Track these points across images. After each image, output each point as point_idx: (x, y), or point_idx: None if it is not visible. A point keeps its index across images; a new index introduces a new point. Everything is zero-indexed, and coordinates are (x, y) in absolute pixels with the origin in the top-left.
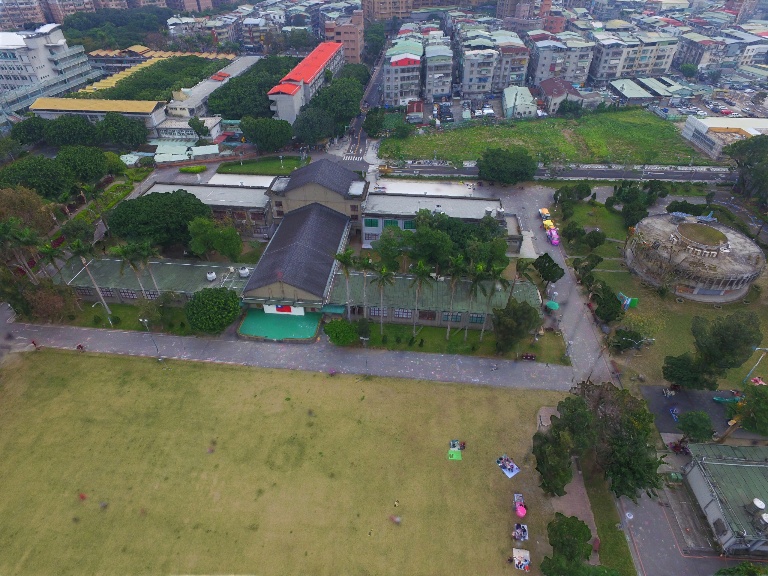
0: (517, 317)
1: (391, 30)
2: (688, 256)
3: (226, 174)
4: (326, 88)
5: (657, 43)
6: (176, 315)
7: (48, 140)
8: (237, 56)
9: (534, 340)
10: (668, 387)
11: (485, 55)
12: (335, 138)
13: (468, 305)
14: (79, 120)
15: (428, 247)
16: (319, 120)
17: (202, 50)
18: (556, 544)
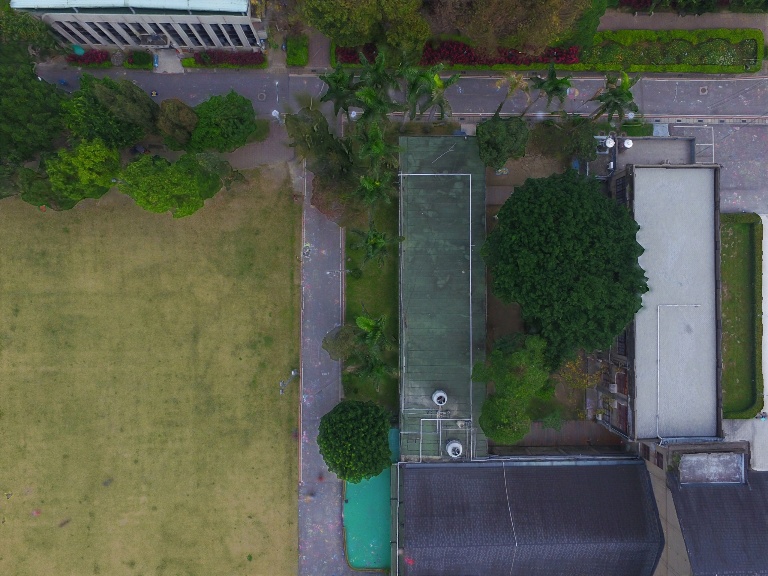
0: None
1: None
2: None
3: None
4: None
5: None
6: None
7: None
8: None
9: None
10: None
11: None
12: None
13: None
14: None
15: None
16: None
17: None
18: None
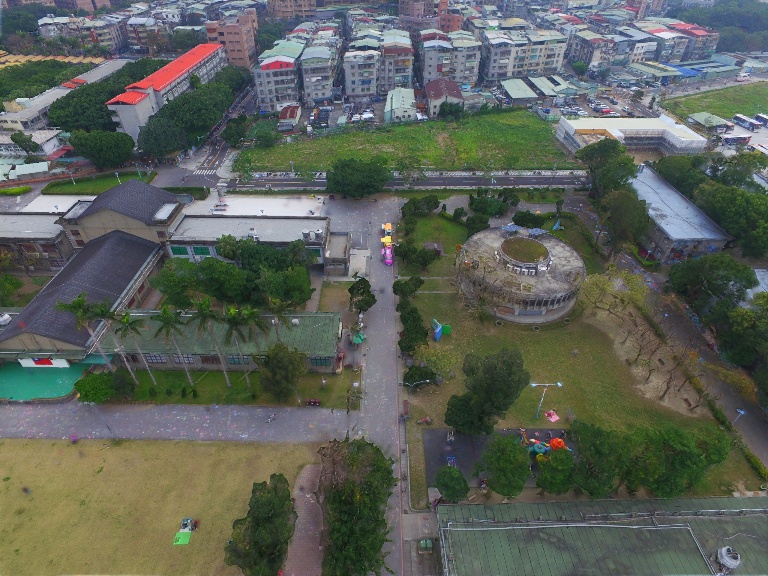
0: (273, 366)
1: None
2: (507, 275)
3: (52, 195)
4: (186, 95)
5: (545, 42)
6: None
7: None
8: (107, 59)
9: None
10: (453, 429)
11: (365, 56)
12: (189, 150)
13: (255, 345)
14: None
15: (214, 281)
16: (164, 131)
17: (67, 53)
18: None
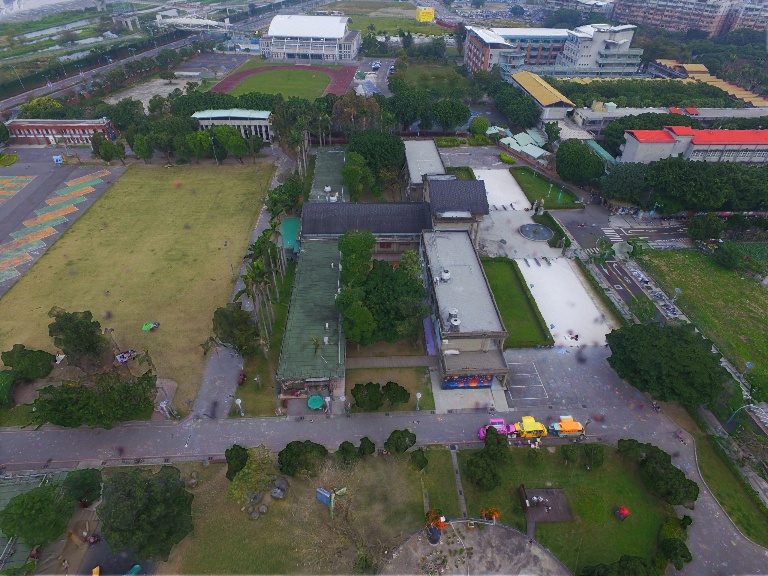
0: None
1: None
2: None
3: (510, 173)
4: (734, 164)
5: None
6: (305, 196)
7: None
8: None
9: None
10: None
11: None
12: (642, 210)
13: (299, 320)
14: (515, 93)
15: None
16: (627, 177)
17: (750, 88)
18: None
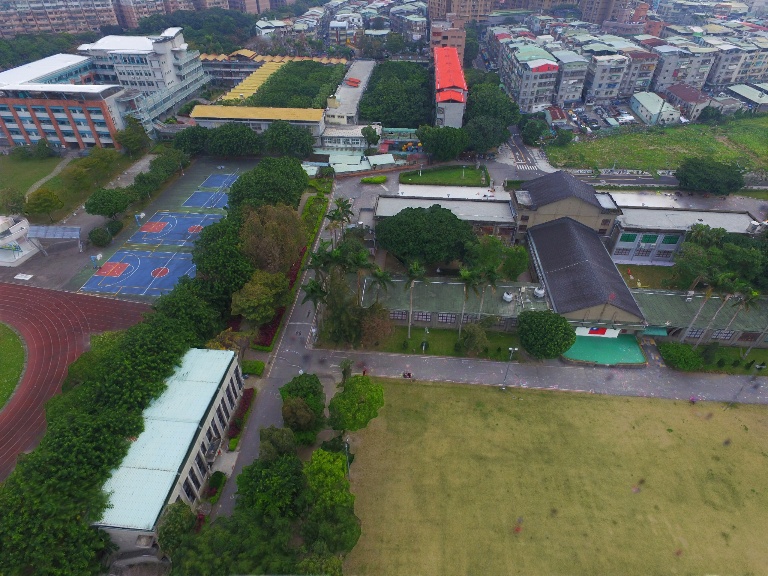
0: None
1: None
2: None
3: (411, 185)
4: (474, 95)
5: None
6: None
7: (212, 150)
8: (348, 61)
9: None
10: None
11: (618, 61)
12: (500, 146)
13: None
14: (246, 129)
15: (738, 265)
16: (494, 128)
17: (311, 54)
18: None
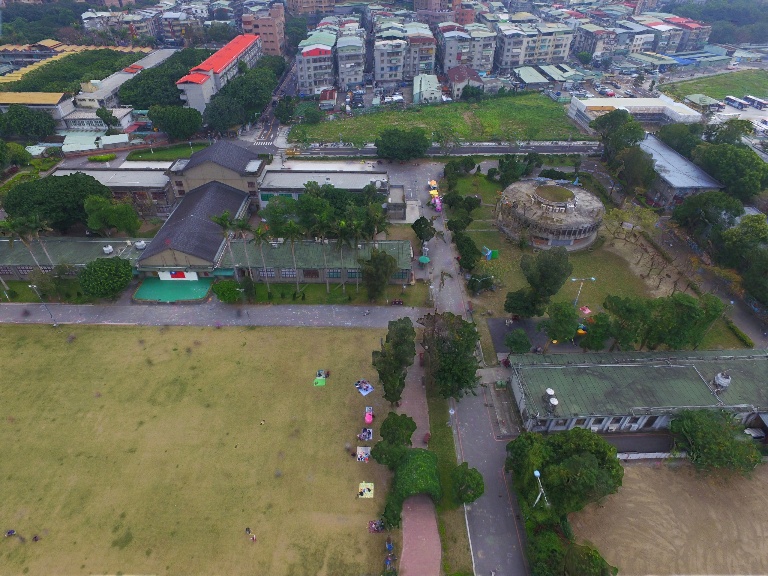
0: (376, 264)
1: (315, 24)
2: None
3: (136, 161)
4: (238, 78)
5: (554, 33)
6: (74, 287)
7: None
8: (154, 49)
9: (403, 288)
10: (510, 318)
11: (393, 45)
12: (247, 125)
13: (347, 262)
14: None
15: (310, 213)
16: (228, 107)
17: (117, 44)
18: (384, 434)
